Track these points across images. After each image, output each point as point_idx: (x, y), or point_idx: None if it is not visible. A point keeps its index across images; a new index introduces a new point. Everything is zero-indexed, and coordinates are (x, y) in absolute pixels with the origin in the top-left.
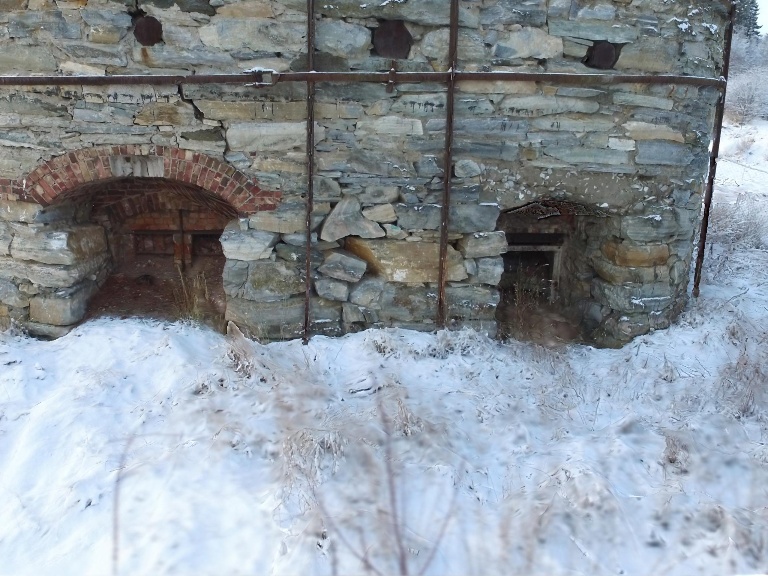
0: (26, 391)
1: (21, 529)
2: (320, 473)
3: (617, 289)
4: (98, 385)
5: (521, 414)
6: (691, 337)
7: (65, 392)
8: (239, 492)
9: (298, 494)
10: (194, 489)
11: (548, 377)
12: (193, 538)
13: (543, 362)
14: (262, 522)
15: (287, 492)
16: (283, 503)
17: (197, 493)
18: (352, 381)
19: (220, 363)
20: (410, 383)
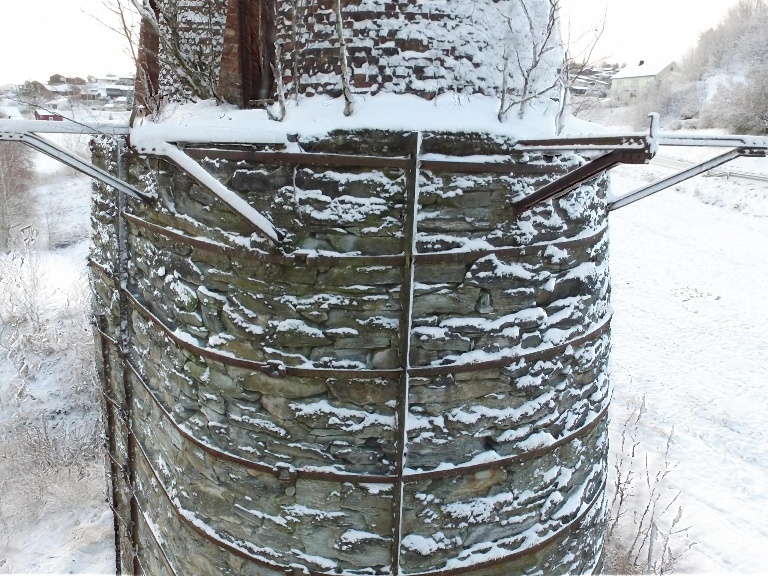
0: None
1: None
2: None
3: None
4: None
5: None
6: None
7: None
8: None
9: None
10: None
11: None
12: None
13: None
14: None
15: None
16: None
17: None
18: None
19: None
20: None
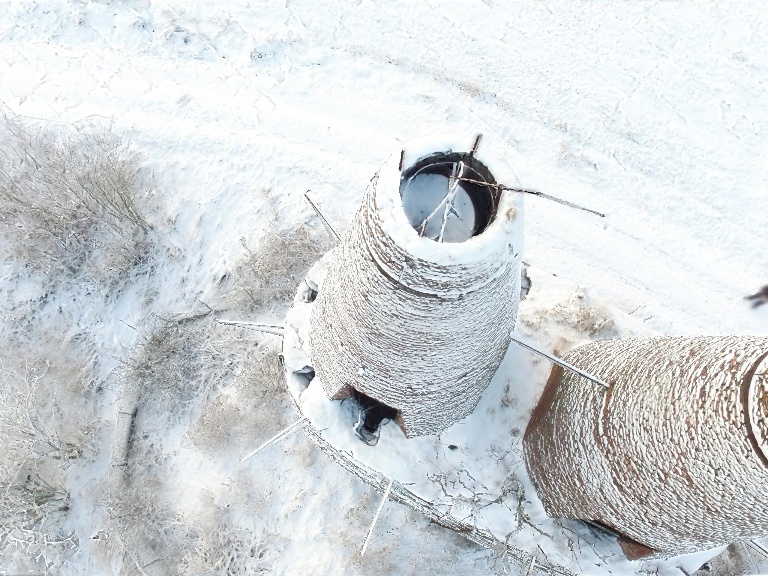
0: (314, 485)
1: (304, 538)
2: (357, 567)
3: None
4: (328, 497)
5: (419, 572)
6: None
7: (321, 496)
8: (341, 559)
9: (350, 570)
10: (334, 552)
11: (451, 555)
12: (327, 570)
13: (459, 546)
14: (339, 574)
15: (347, 569)
16: (345, 572)
17: (334, 554)
18: (392, 526)
19: (362, 498)
20: (407, 535)
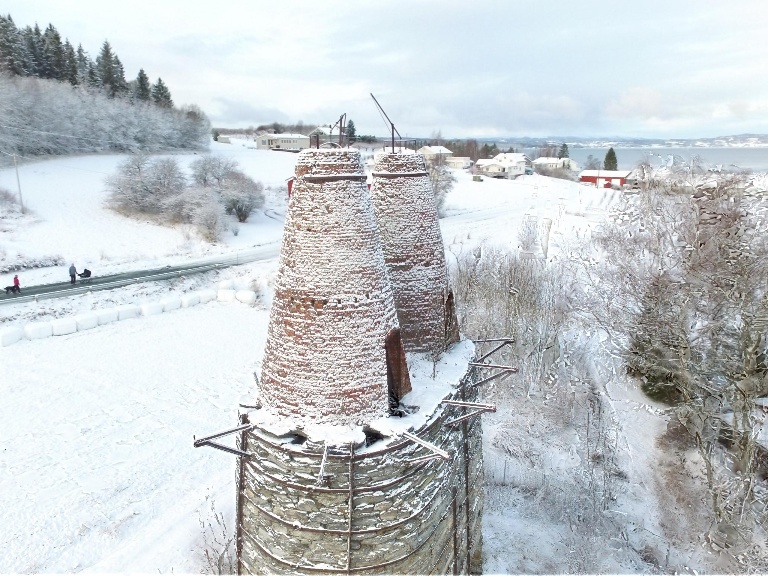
0: None
1: None
2: None
3: (477, 567)
4: None
5: None
6: (492, 568)
7: None
8: None
9: None
10: None
11: None
12: None
13: None
14: None
15: None
16: None
17: None
18: None
19: None
20: None
